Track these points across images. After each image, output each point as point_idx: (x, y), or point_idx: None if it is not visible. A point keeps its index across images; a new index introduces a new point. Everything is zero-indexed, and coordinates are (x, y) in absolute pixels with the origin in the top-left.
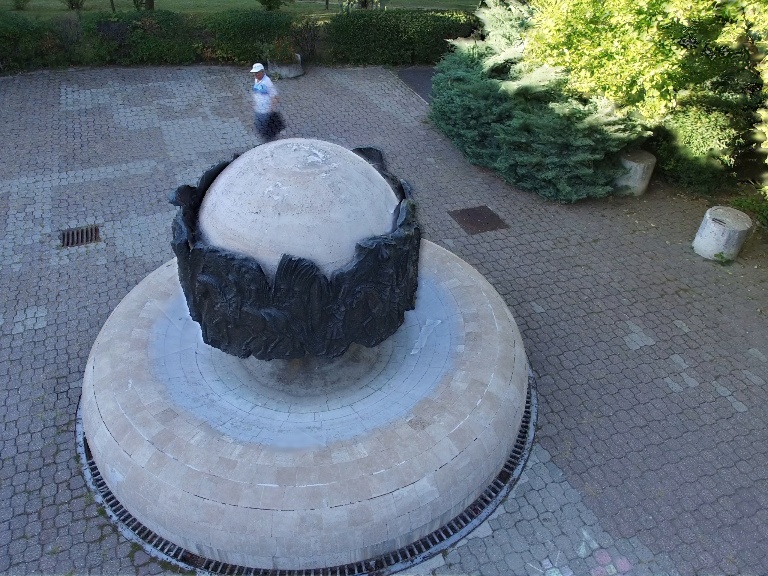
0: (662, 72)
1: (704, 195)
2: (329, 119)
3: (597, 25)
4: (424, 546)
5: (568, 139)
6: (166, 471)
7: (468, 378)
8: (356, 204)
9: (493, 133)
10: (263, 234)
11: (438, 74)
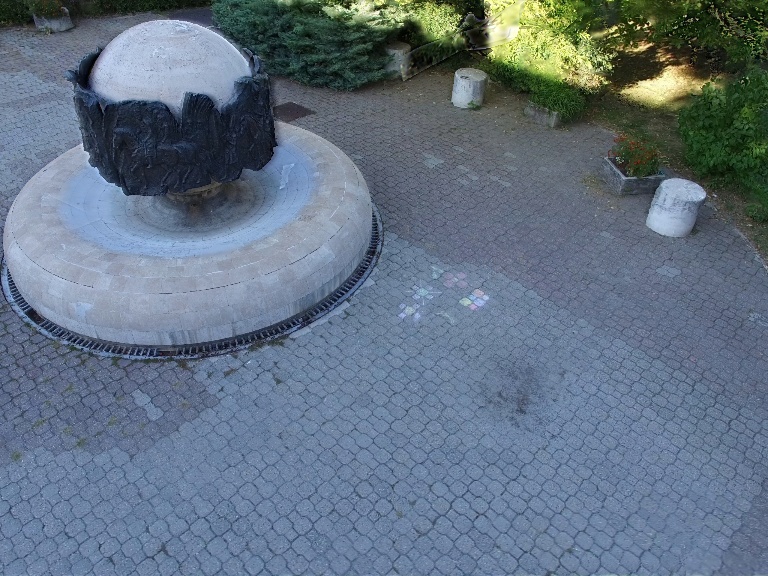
0: None
1: (450, 69)
2: None
3: None
4: (333, 300)
5: (342, 36)
6: (129, 286)
7: (329, 188)
8: (224, 57)
9: (280, 44)
10: (161, 85)
11: (215, 3)
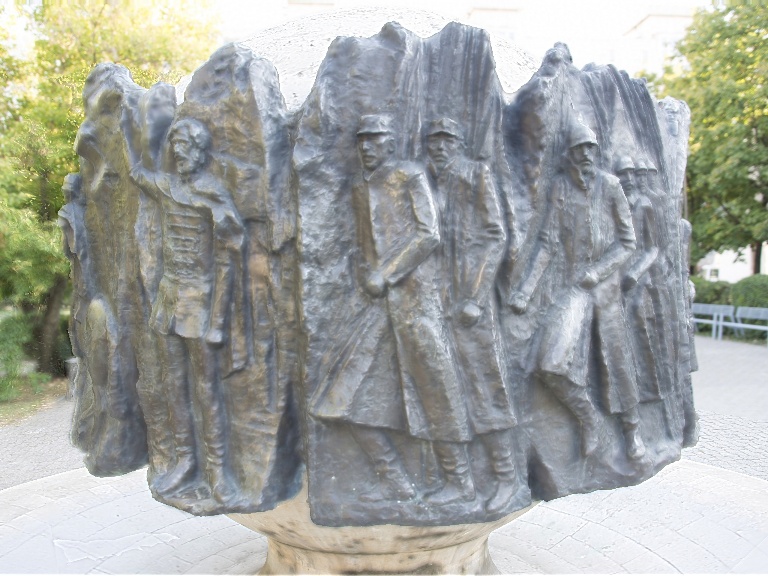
0: None
1: None
2: None
3: None
4: None
5: None
6: None
7: None
8: None
9: None
10: None
11: None
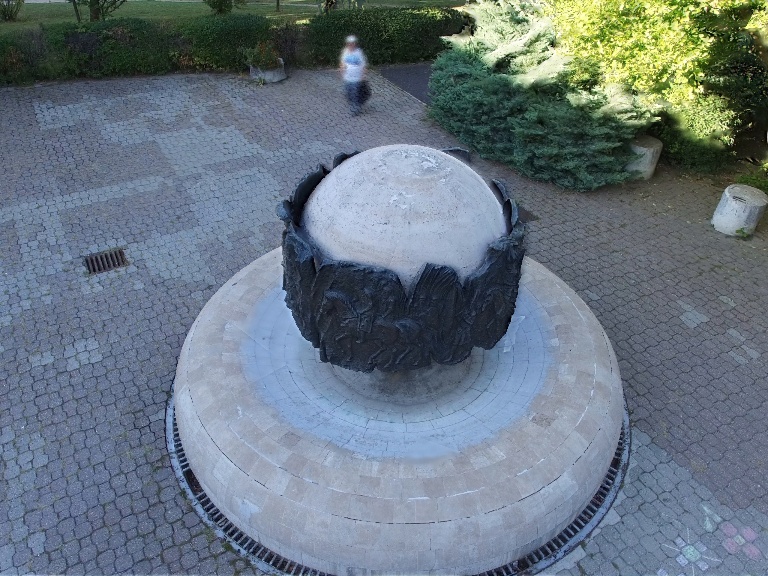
0: (693, 60)
1: (707, 175)
2: (327, 122)
3: (628, 17)
4: (561, 540)
5: (584, 129)
6: (309, 497)
7: (574, 370)
8: (477, 207)
9: (505, 127)
10: (395, 245)
11: (437, 71)
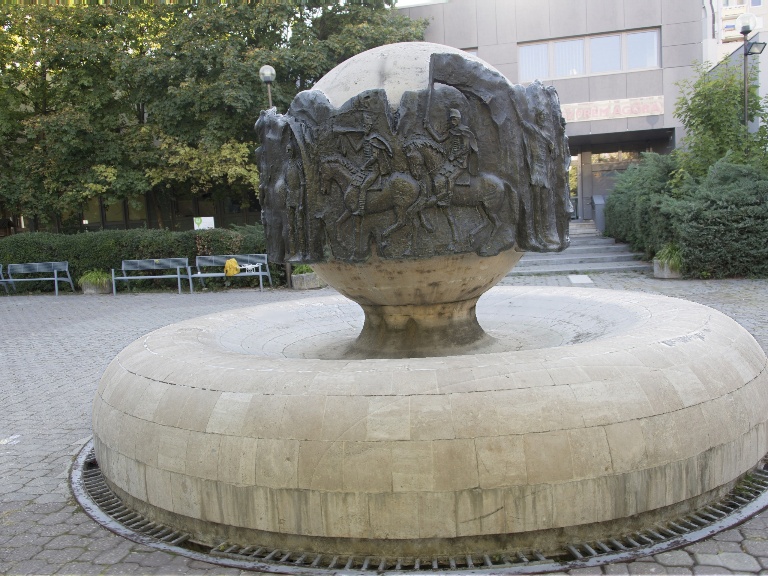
0: None
1: None
2: None
3: None
4: None
5: None
6: None
7: (184, 344)
8: None
9: None
10: None
11: None
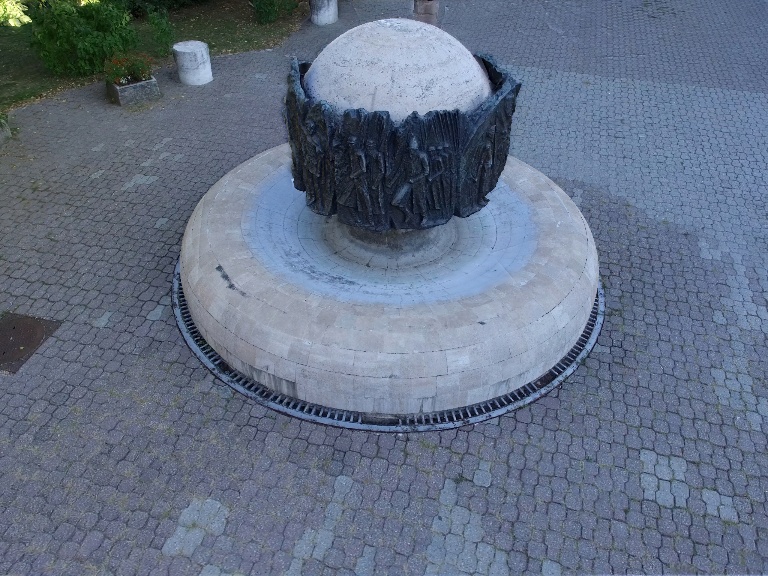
0: None
1: None
2: None
3: None
4: None
5: None
6: None
7: None
8: None
9: None
10: None
11: None
